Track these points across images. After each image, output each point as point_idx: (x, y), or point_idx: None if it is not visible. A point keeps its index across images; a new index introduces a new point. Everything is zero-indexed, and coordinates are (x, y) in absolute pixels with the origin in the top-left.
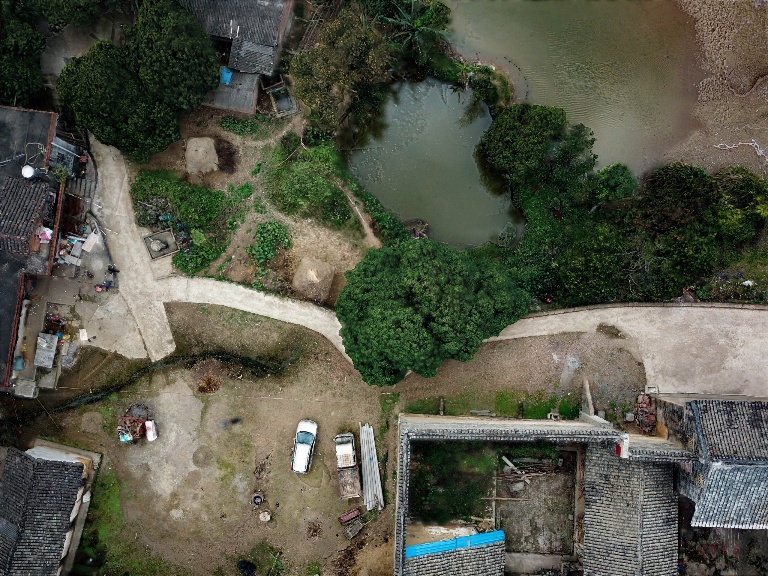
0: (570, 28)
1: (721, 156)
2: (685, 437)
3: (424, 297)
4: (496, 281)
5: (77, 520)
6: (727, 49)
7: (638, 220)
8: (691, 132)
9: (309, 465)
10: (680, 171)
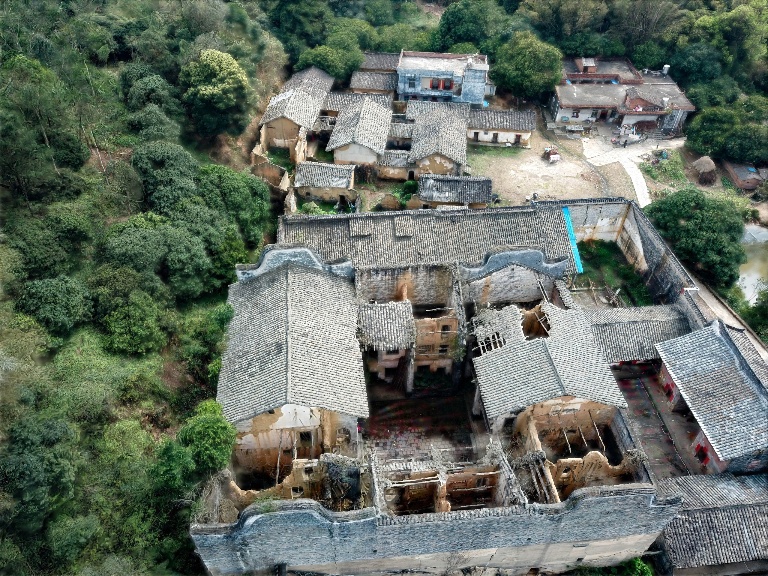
0: None
1: None
2: None
3: (712, 203)
4: (740, 247)
5: (495, 144)
6: None
7: None
8: None
9: None
10: None
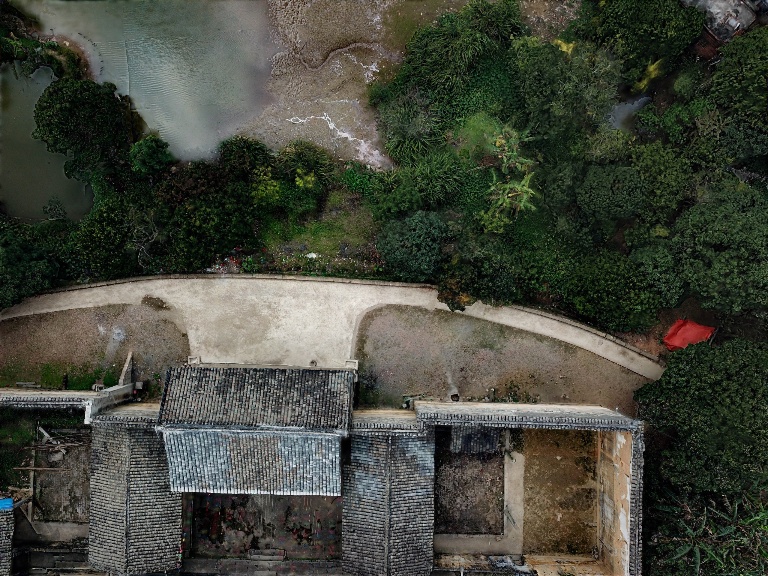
0: (145, 3)
1: (293, 130)
2: None
3: None
4: None
5: None
6: (300, 23)
7: (161, 192)
8: (264, 106)
9: None
10: (233, 144)
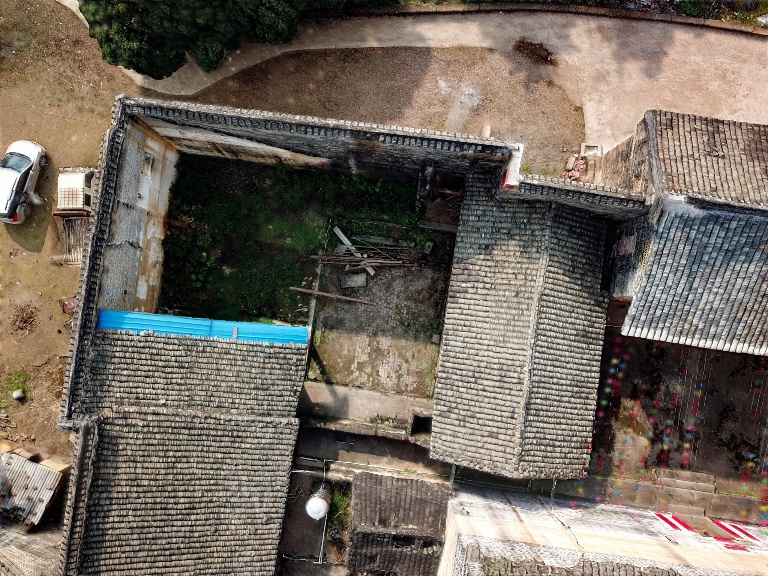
0: None
1: None
2: (629, 182)
3: None
4: None
5: None
6: None
7: None
8: None
9: (17, 207)
10: None
